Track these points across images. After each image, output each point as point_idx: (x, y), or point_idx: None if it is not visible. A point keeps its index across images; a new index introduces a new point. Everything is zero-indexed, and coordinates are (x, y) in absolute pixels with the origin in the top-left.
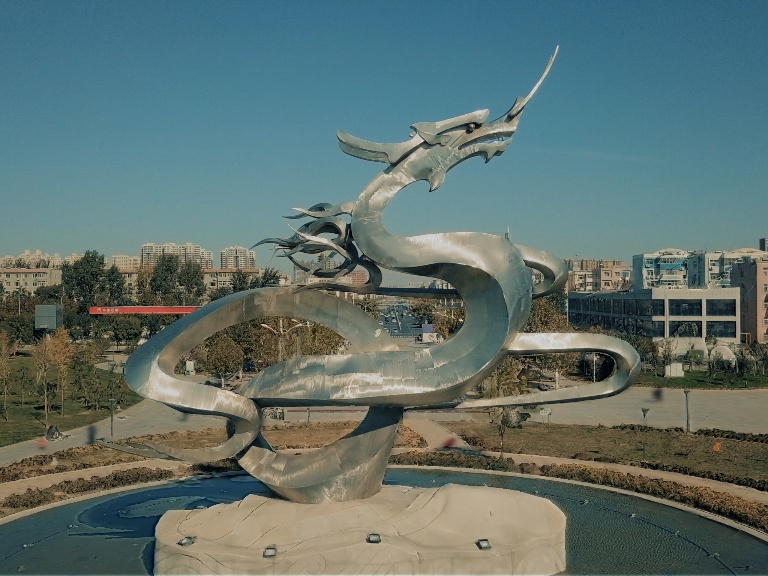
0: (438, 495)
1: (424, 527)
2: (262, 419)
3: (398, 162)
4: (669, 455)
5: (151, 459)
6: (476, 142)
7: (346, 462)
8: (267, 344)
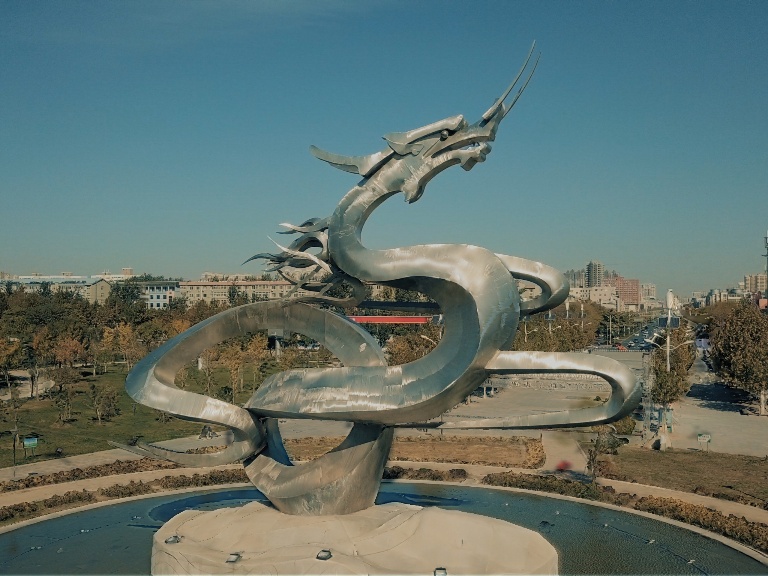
0: (413, 517)
1: (388, 549)
2: (263, 429)
3: (371, 174)
4: None
5: None
6: (451, 149)
7: (326, 476)
8: (420, 355)
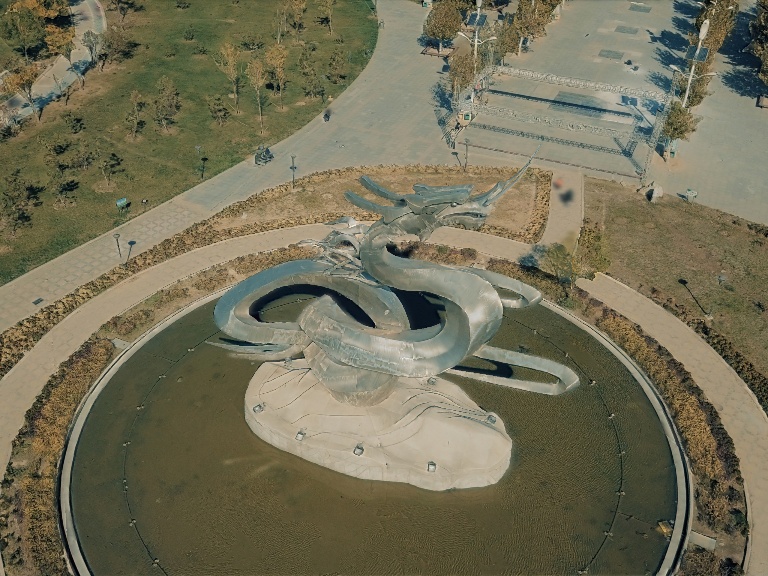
0: (418, 419)
1: (401, 441)
2: None
3: None
4: (749, 305)
5: (313, 220)
6: (459, 214)
7: (360, 385)
8: (454, 65)
